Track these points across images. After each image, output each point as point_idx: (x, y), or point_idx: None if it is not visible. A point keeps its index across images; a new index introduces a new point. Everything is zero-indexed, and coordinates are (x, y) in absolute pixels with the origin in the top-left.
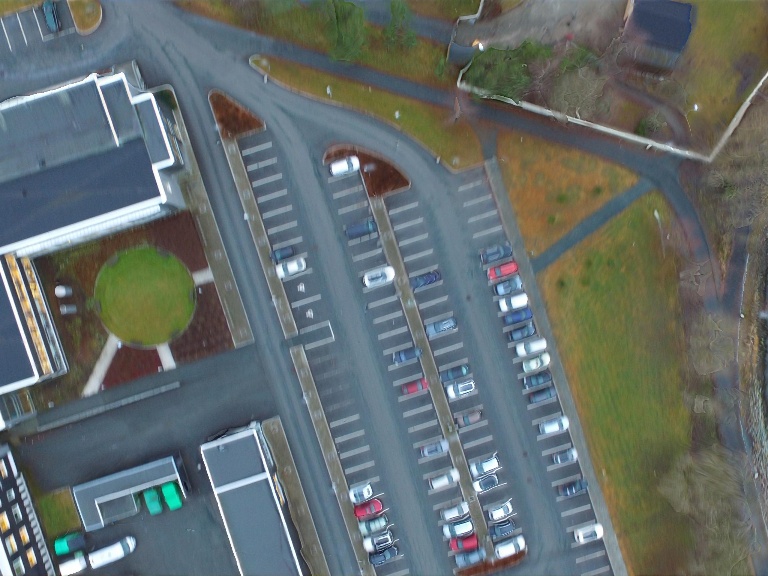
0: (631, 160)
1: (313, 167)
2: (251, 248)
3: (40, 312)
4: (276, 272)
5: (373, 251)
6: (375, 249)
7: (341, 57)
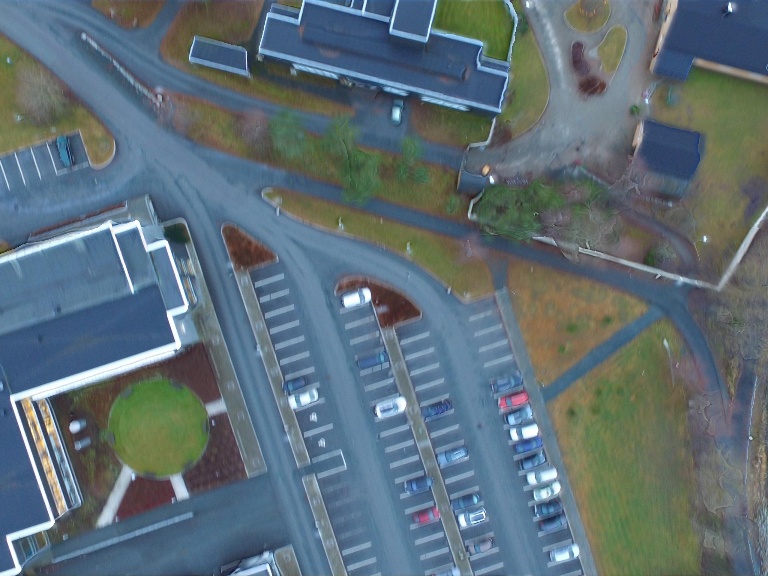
0: (640, 289)
1: (325, 298)
2: (264, 379)
3: (55, 448)
4: (288, 403)
5: (385, 381)
6: (387, 379)
7: (354, 199)
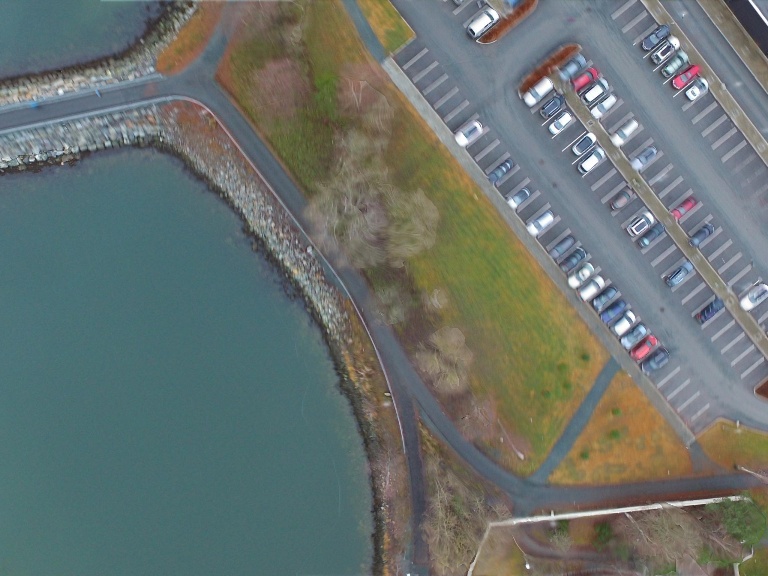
0: (562, 495)
1: None
2: None
3: None
4: None
5: (766, 318)
6: (765, 320)
7: None
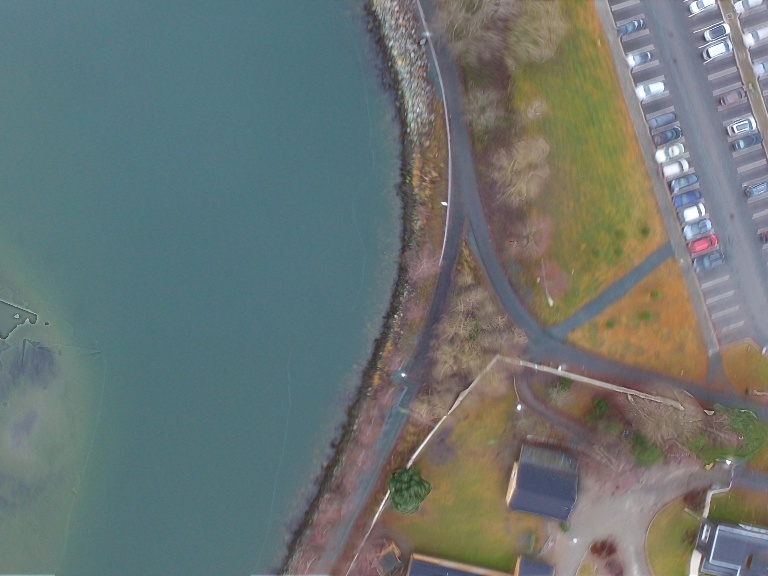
0: (575, 355)
1: None
2: None
3: None
4: None
5: None
6: None
7: None
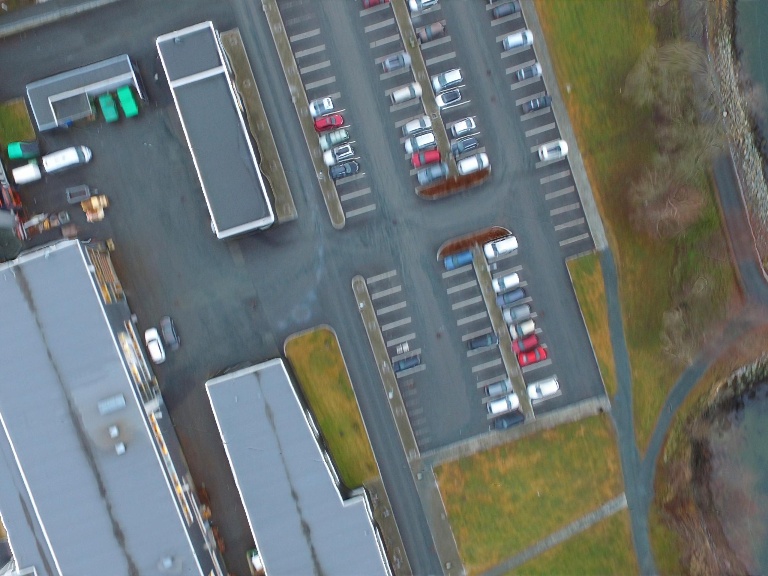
0: None
1: None
2: None
3: None
4: None
5: None
6: None
7: None
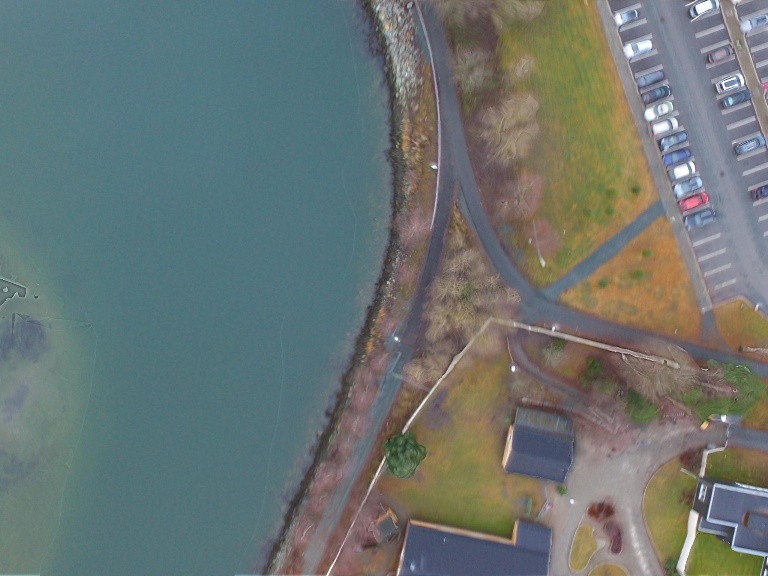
0: (568, 316)
1: None
2: None
3: None
4: None
5: None
6: None
7: None
